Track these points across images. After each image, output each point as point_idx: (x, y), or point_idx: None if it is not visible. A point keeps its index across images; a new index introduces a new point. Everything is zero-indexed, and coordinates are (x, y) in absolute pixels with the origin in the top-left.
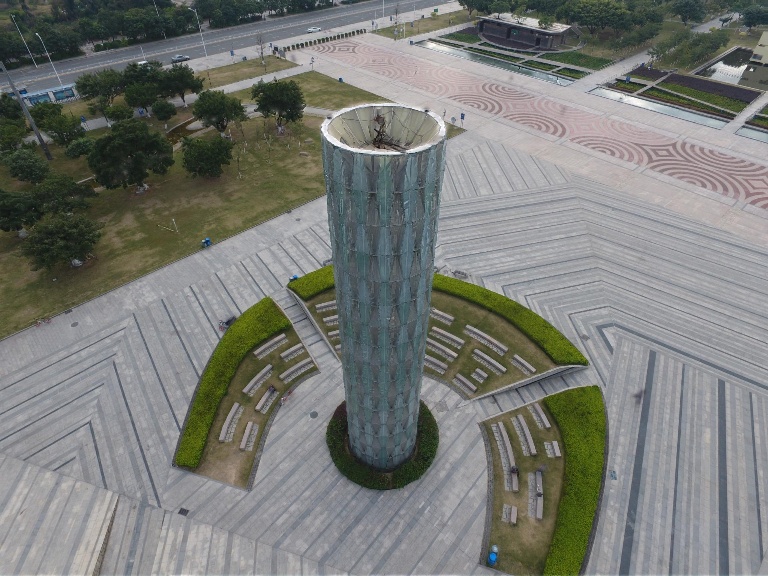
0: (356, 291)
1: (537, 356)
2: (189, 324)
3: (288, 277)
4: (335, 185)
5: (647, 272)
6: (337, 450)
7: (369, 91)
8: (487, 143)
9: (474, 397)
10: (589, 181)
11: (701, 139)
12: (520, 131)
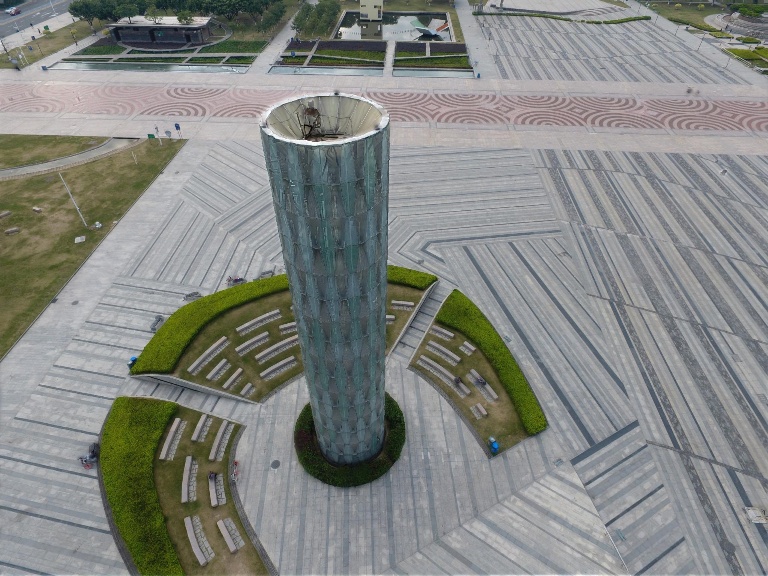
0: (343, 290)
1: (407, 293)
2: (34, 493)
3: (122, 365)
4: (315, 189)
5: (419, 195)
6: (328, 472)
7: (36, 134)
8: (218, 144)
9: (388, 352)
10: None
11: (376, 87)
12: (239, 124)
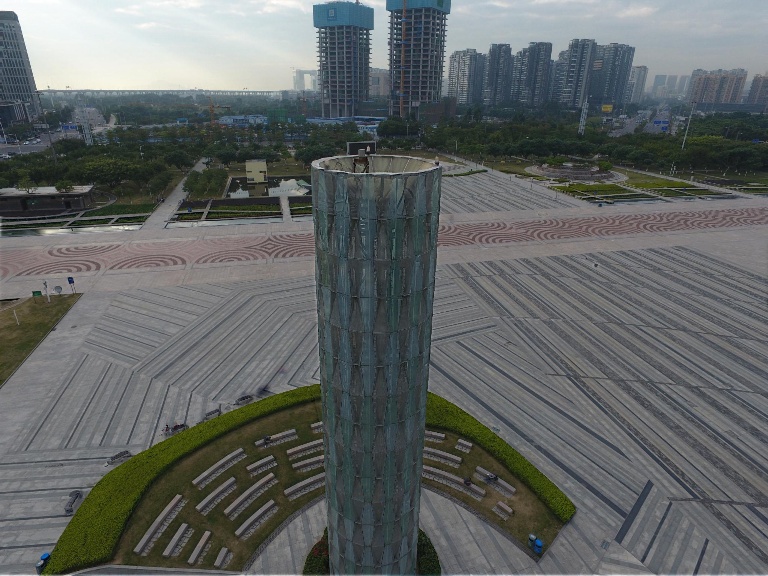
0: (403, 350)
1: None
2: None
3: (24, 572)
4: (389, 224)
5: None
6: None
7: None
8: (121, 294)
9: None
10: (247, 282)
11: (280, 231)
12: (142, 273)
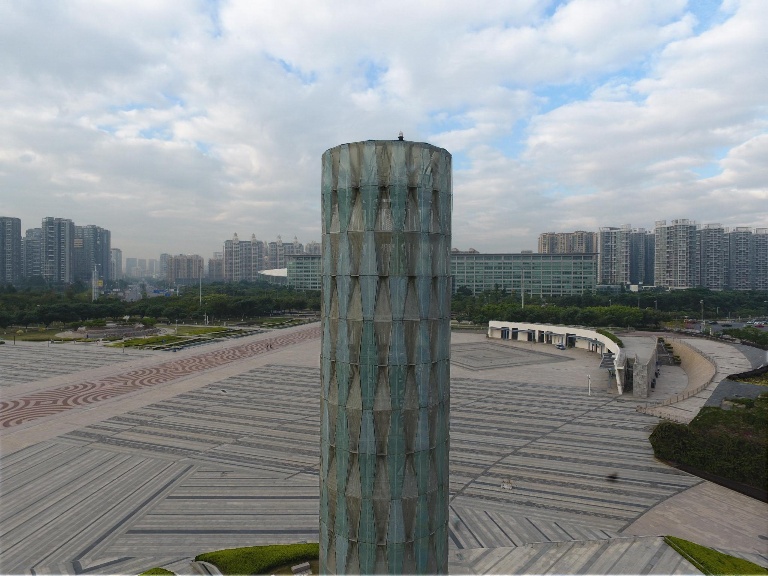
0: None
1: None
2: None
3: None
4: (450, 199)
5: None
6: None
7: None
8: None
9: None
10: None
11: None
12: None
